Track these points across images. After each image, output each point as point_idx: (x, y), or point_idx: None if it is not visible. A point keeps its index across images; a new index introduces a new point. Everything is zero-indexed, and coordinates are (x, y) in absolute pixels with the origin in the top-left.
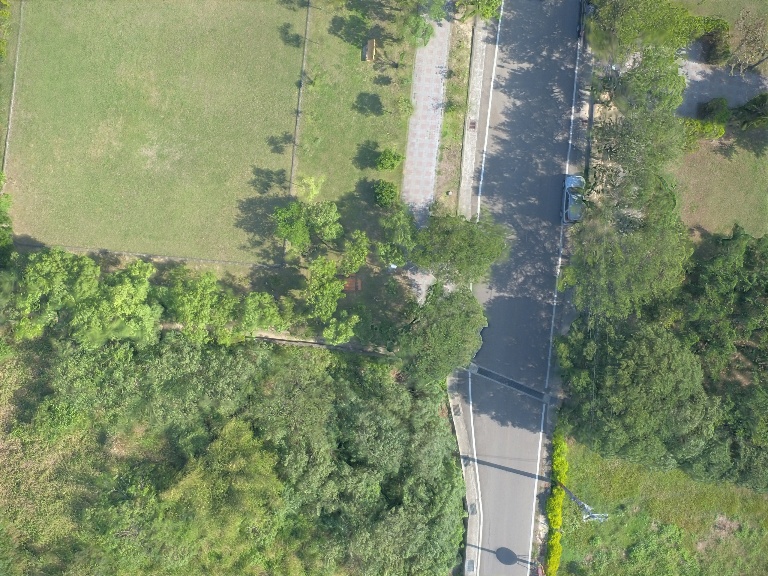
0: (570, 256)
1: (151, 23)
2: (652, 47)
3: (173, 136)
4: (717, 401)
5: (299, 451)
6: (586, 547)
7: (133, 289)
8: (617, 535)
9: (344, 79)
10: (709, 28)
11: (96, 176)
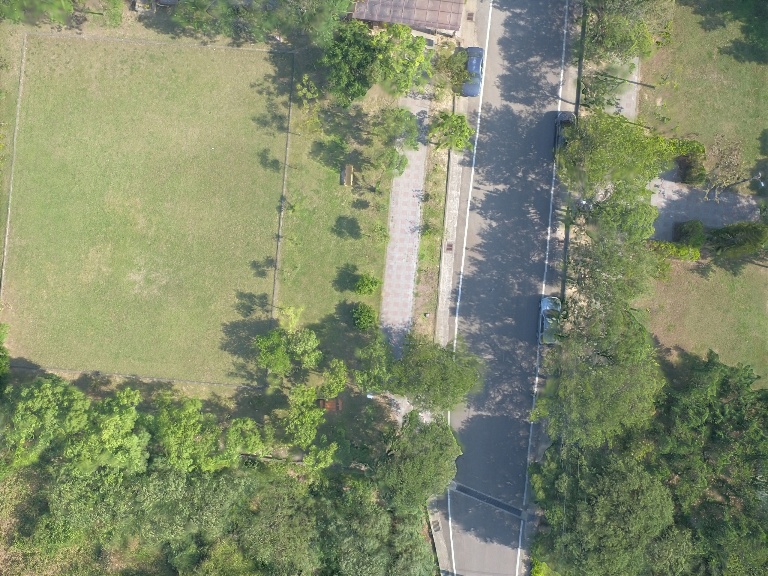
0: (547, 375)
1: (137, 152)
2: (623, 181)
3: (159, 262)
4: (687, 536)
5: (281, 574)
6: None
7: (120, 423)
8: None
9: (323, 204)
10: (684, 151)
11: (87, 301)
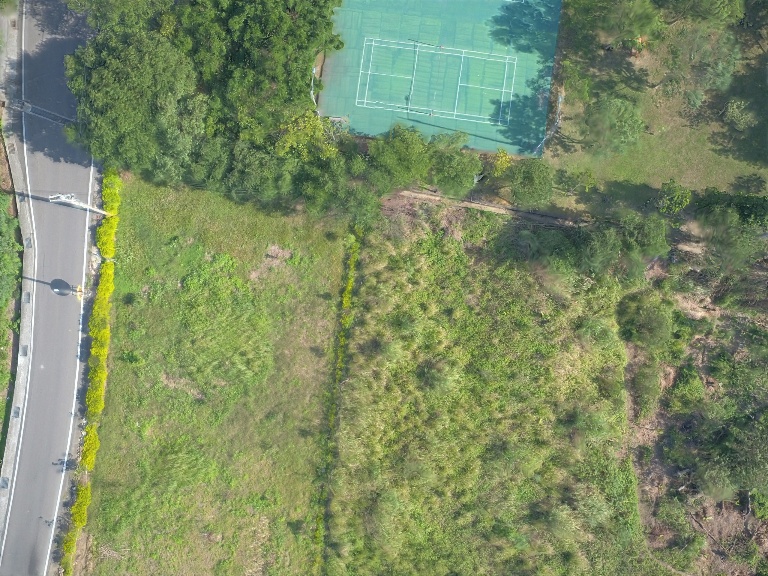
0: None
1: None
2: None
3: None
4: (200, 95)
5: None
6: (141, 278)
7: None
8: (171, 265)
9: None
10: None
11: None
